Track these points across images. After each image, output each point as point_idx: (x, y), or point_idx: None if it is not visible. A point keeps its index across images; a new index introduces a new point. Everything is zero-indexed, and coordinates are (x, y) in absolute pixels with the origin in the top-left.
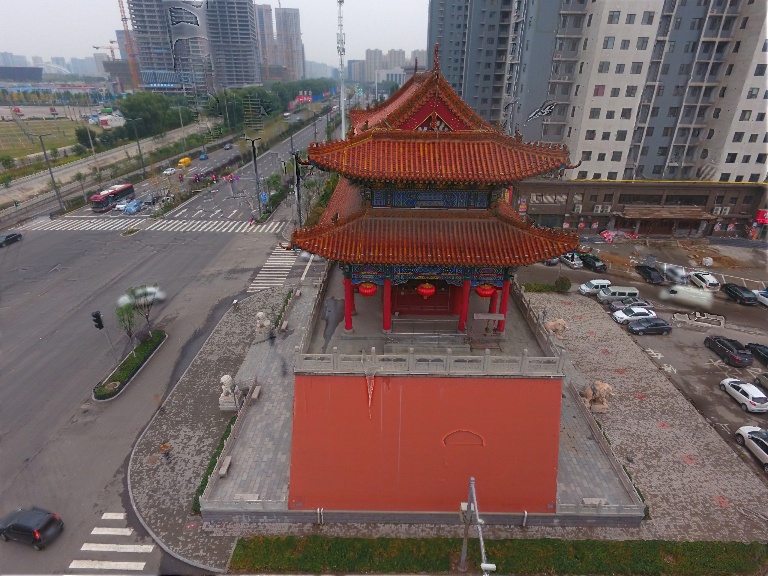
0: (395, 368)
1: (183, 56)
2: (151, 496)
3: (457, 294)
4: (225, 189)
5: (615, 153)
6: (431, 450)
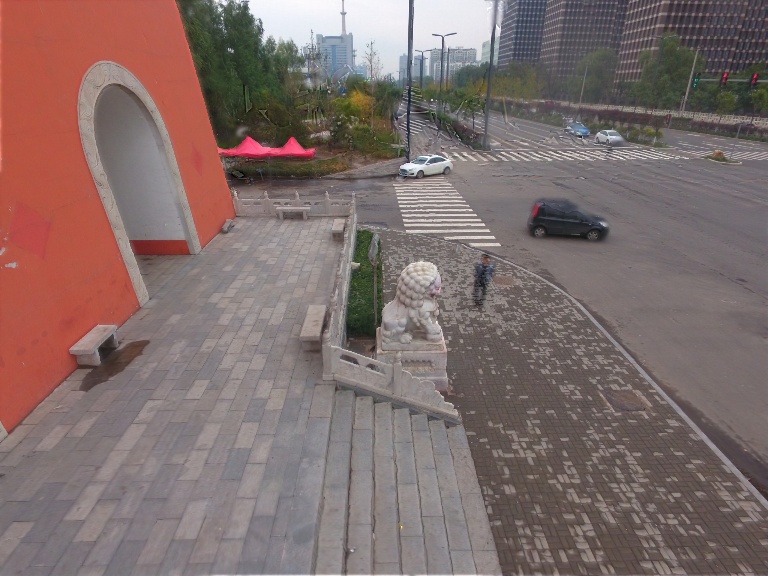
0: None
1: None
2: None
3: None
4: None
5: None
6: None
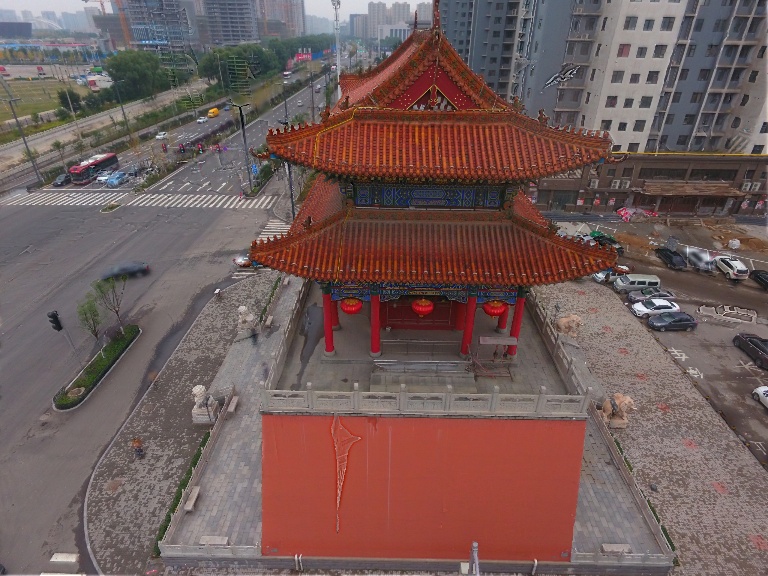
0: (383, 407)
1: (155, 11)
2: (108, 532)
3: (460, 307)
4: (213, 160)
5: (638, 122)
6: (426, 496)
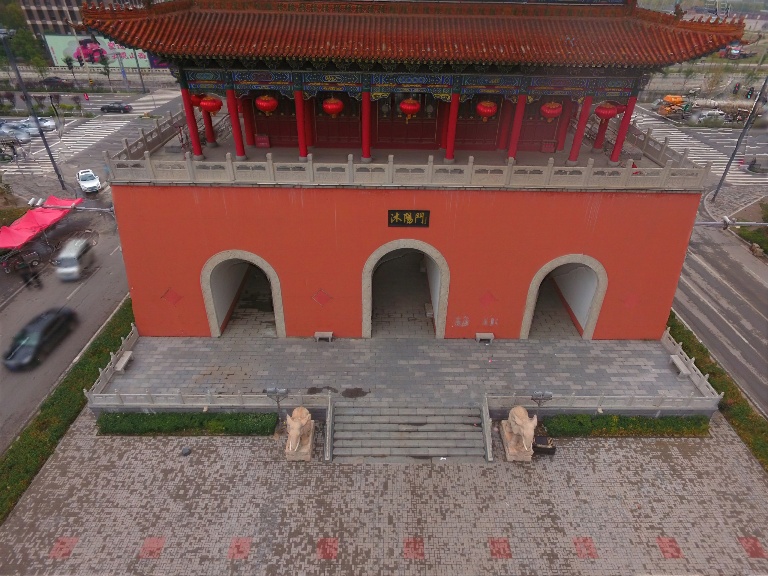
0: None
1: None
2: None
3: None
4: None
5: None
6: None
